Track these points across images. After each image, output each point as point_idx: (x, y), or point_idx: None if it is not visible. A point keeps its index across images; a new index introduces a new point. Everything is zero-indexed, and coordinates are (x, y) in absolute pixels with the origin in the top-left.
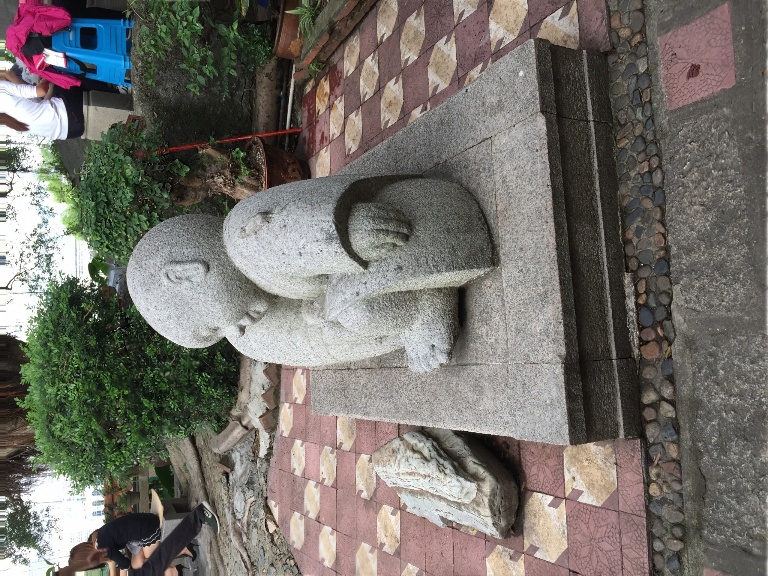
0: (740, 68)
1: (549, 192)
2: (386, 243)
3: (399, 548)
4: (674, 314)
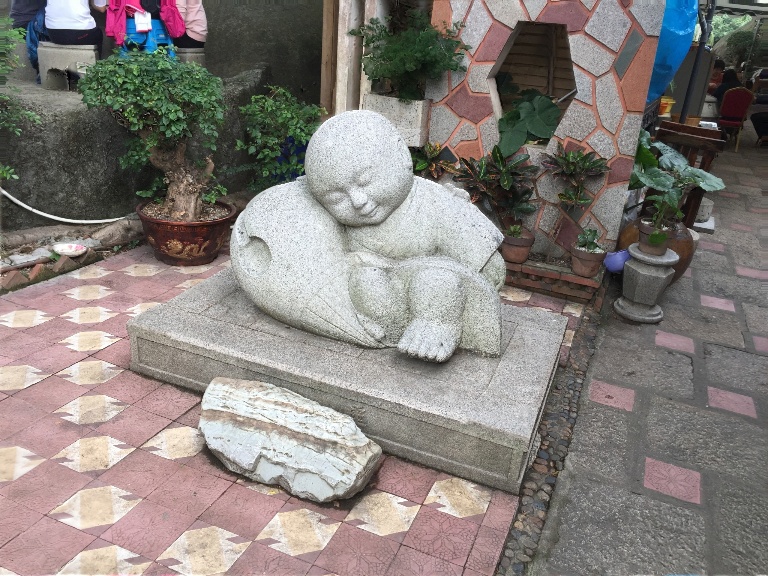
0: (635, 409)
1: (555, 357)
2: (499, 277)
3: (103, 471)
4: (567, 461)
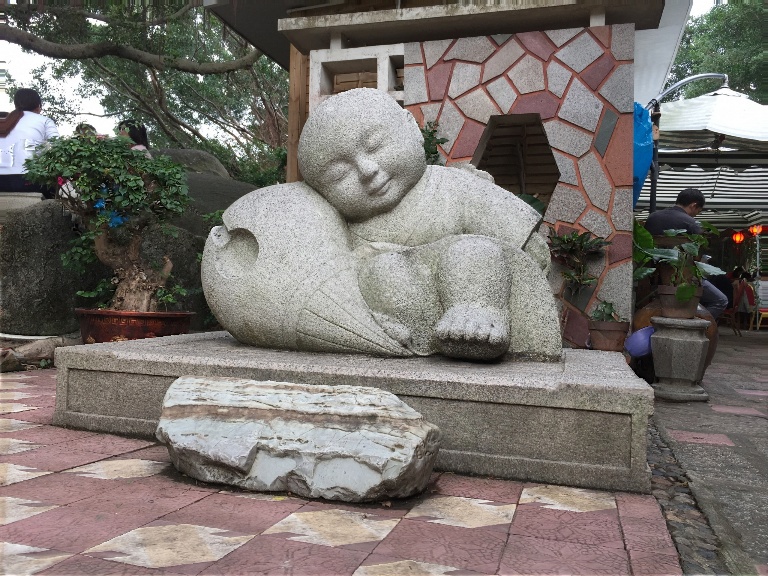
0: None
1: None
2: None
3: None
4: (690, 475)
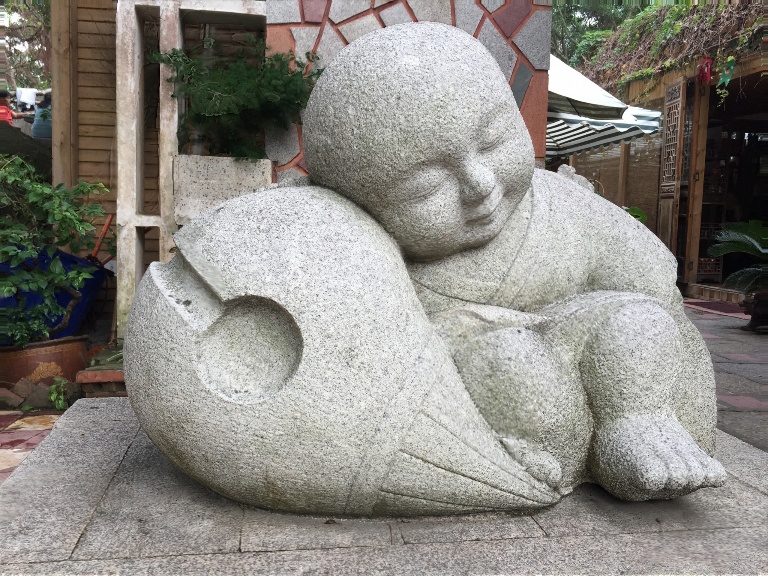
0: None
1: None
2: None
3: None
4: None
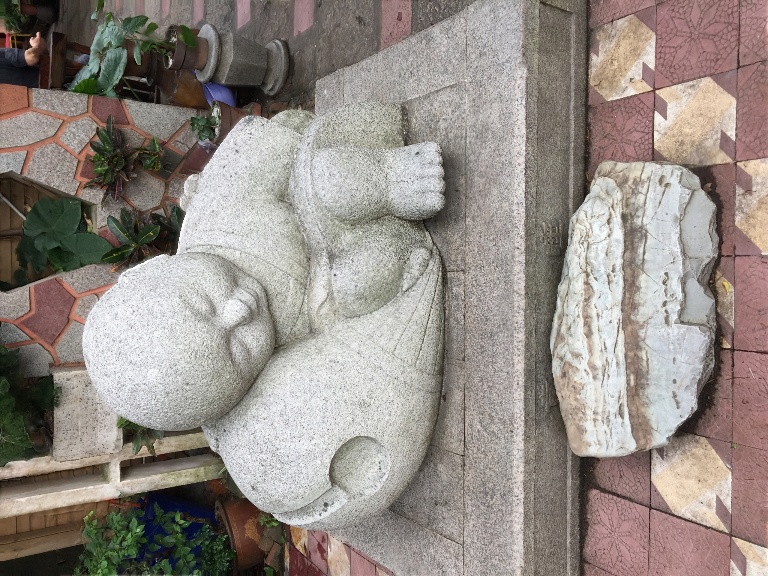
0: None
1: None
2: None
3: None
4: None
